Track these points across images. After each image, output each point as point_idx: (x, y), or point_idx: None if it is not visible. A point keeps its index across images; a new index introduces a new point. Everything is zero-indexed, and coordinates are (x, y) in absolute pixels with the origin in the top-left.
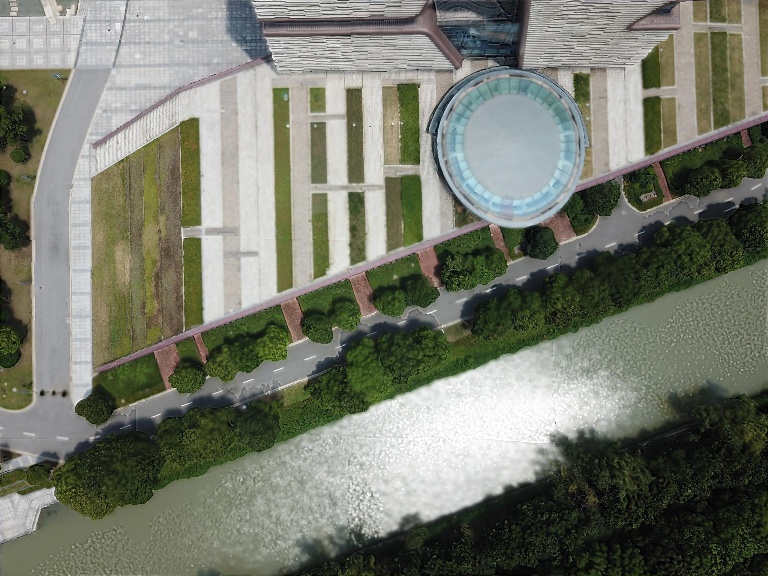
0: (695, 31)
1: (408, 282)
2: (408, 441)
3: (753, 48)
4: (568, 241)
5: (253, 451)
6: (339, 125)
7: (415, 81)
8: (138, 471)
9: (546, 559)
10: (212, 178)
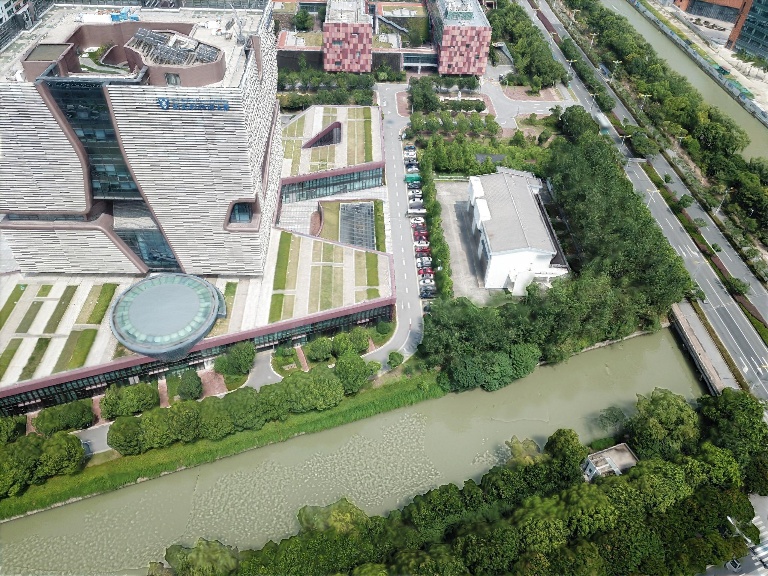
0: (312, 265)
1: None
2: (27, 572)
3: (350, 274)
4: (221, 394)
5: None
6: (53, 303)
7: (117, 283)
8: None
9: None
10: None
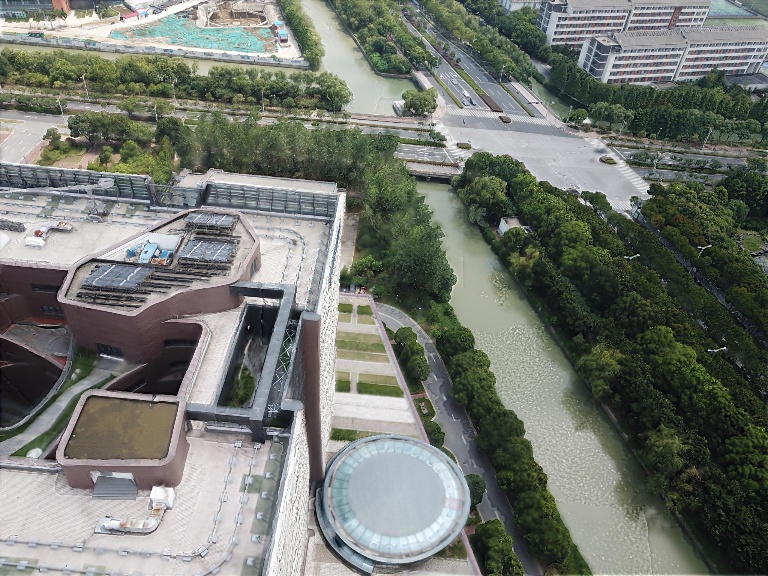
0: None
1: None
2: None
3: None
4: None
5: None
6: None
7: None
8: None
9: (759, 518)
10: None
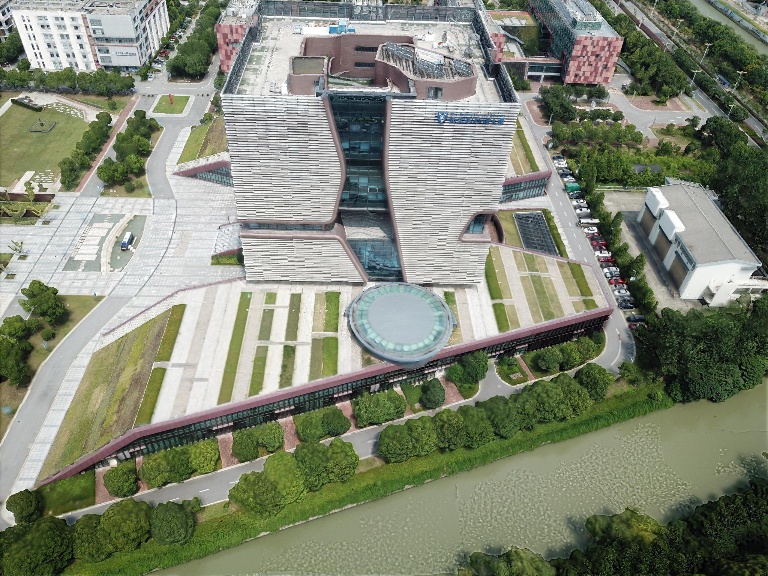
0: (520, 275)
1: None
2: None
3: (560, 284)
4: (458, 403)
5: (161, 565)
6: (283, 311)
7: (338, 291)
8: (47, 538)
9: None
10: (186, 335)
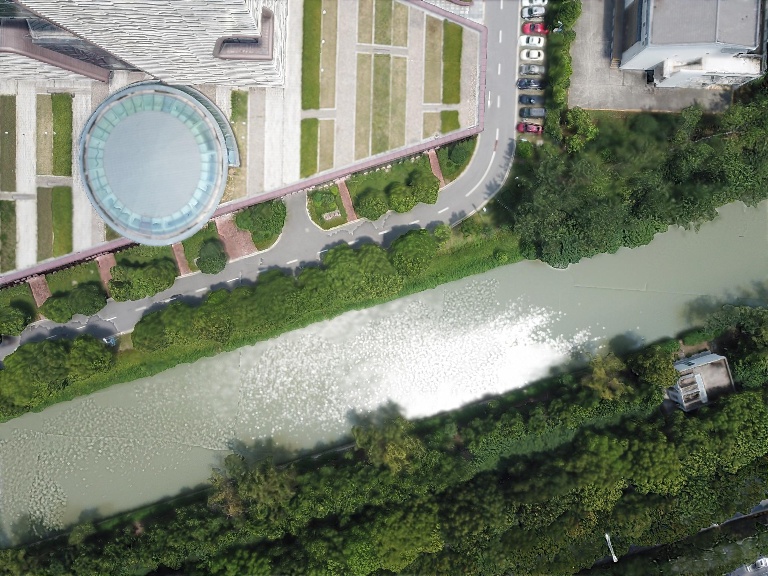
0: (359, 52)
1: (72, 290)
2: (97, 440)
3: (417, 72)
4: (250, 255)
5: None
6: None
7: (70, 90)
8: None
9: (195, 562)
10: None
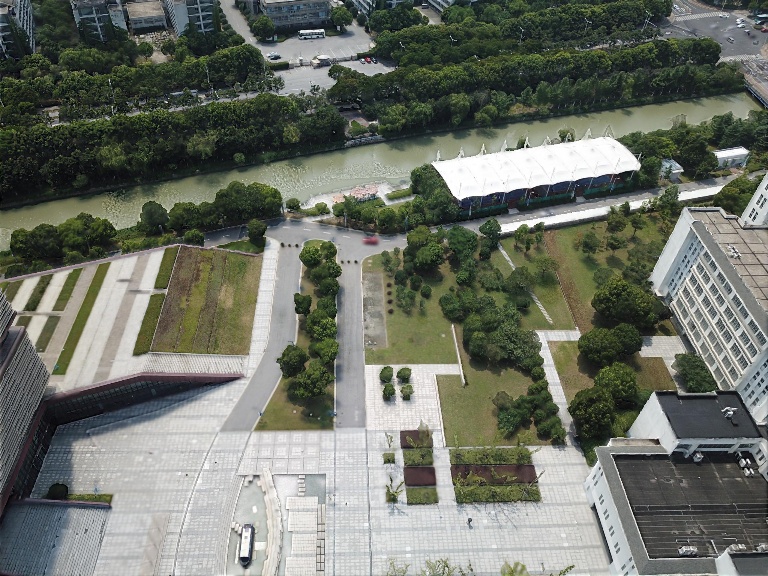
0: None
1: None
2: None
3: None
4: None
5: None
6: None
7: None
8: None
9: None
10: (135, 321)
